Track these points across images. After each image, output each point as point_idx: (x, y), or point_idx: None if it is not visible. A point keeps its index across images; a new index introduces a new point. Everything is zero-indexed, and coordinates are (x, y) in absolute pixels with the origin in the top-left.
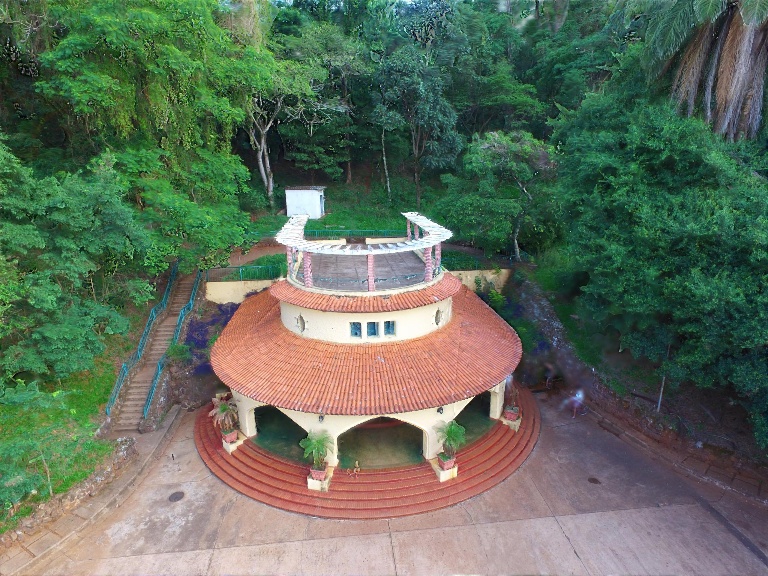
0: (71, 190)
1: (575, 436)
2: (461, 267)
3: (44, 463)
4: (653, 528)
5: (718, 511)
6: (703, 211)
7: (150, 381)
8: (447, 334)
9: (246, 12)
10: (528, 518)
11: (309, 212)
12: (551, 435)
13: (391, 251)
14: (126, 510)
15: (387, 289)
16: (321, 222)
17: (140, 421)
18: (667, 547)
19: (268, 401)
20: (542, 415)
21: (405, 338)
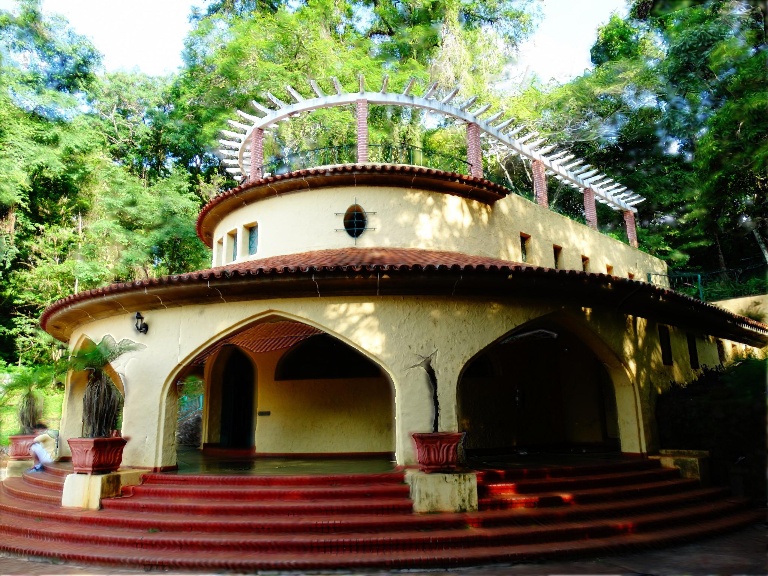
0: None
1: None
2: (762, 288)
3: None
4: None
5: None
6: None
7: None
8: (358, 248)
9: None
10: None
11: None
12: None
13: (279, 113)
14: None
15: None
16: None
17: None
18: None
19: None
20: (668, 550)
21: (271, 254)
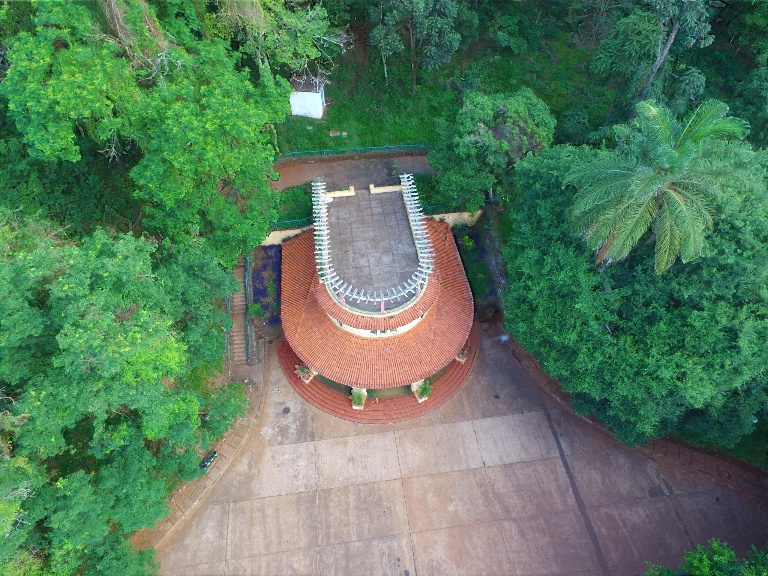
0: (182, 263)
1: (496, 363)
2: (445, 210)
3: (217, 402)
4: (516, 426)
5: (550, 416)
6: (567, 325)
7: (243, 331)
8: (427, 323)
9: (248, 3)
10: (459, 422)
11: (312, 112)
12: (483, 362)
13: None
14: (265, 420)
15: (392, 311)
16: (325, 126)
17: (247, 359)
18: (518, 437)
19: (330, 378)
20: (481, 345)
21: (402, 332)
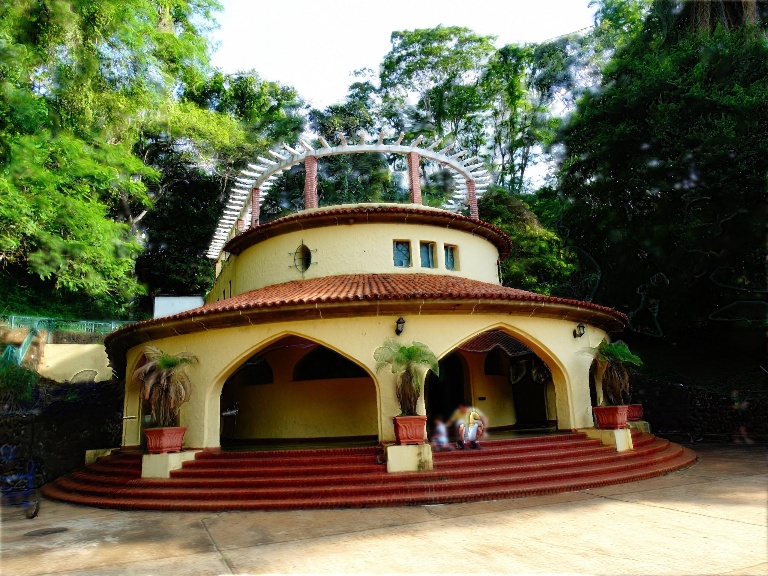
0: None
1: None
2: None
3: None
4: None
5: None
6: None
7: None
8: None
9: None
10: None
11: None
12: None
13: (439, 156)
14: None
15: None
16: None
17: None
18: None
19: None
20: None
21: (471, 277)
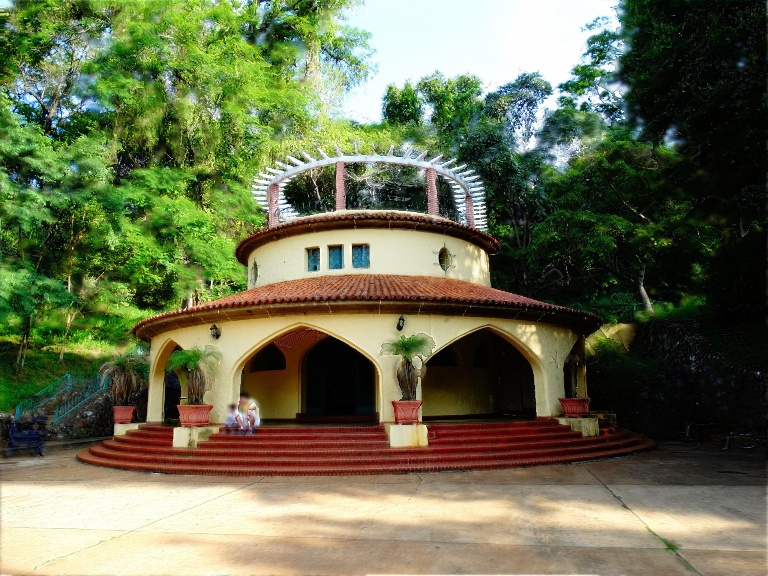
0: None
1: None
2: None
3: None
4: None
5: None
6: None
7: None
8: None
9: (309, 82)
10: (541, 483)
11: None
12: None
13: (368, 158)
14: None
15: None
16: None
17: None
18: None
19: None
20: (659, 448)
21: (384, 272)
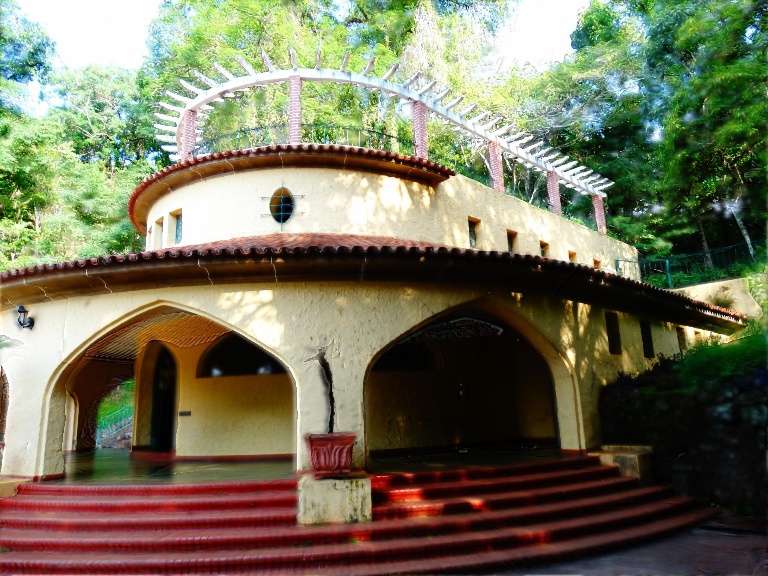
0: None
1: None
2: (731, 272)
3: None
4: None
5: None
6: None
7: None
8: (282, 234)
9: None
10: None
11: None
12: None
13: (210, 93)
14: None
15: None
16: None
17: None
18: None
19: None
20: (580, 562)
21: (194, 243)
